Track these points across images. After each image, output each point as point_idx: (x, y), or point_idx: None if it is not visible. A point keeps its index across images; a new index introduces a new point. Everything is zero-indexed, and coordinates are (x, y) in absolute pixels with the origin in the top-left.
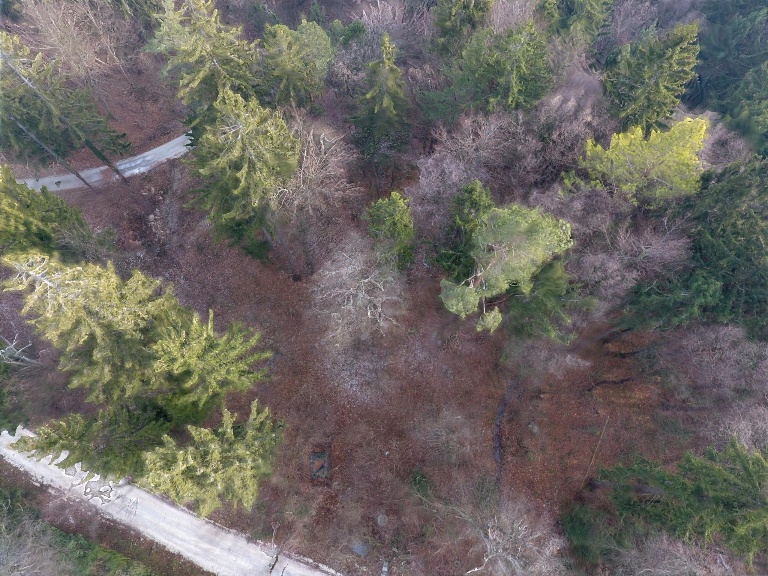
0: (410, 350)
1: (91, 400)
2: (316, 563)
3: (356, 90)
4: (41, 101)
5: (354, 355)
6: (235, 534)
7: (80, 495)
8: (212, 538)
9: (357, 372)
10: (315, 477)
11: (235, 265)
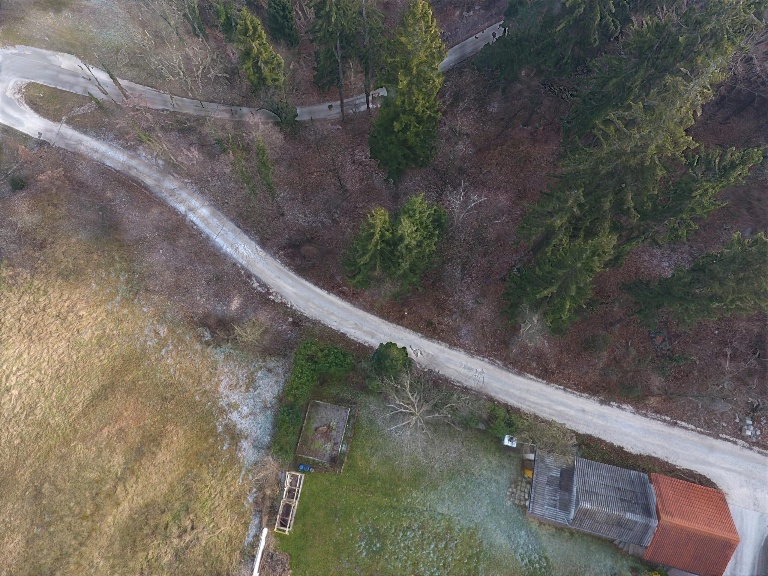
0: (726, 244)
1: (556, 243)
2: (674, 420)
3: (696, 3)
4: (363, 19)
5: (671, 248)
6: (587, 398)
7: (427, 366)
8: (564, 401)
9: (676, 263)
10: (659, 349)
11: (511, 180)
